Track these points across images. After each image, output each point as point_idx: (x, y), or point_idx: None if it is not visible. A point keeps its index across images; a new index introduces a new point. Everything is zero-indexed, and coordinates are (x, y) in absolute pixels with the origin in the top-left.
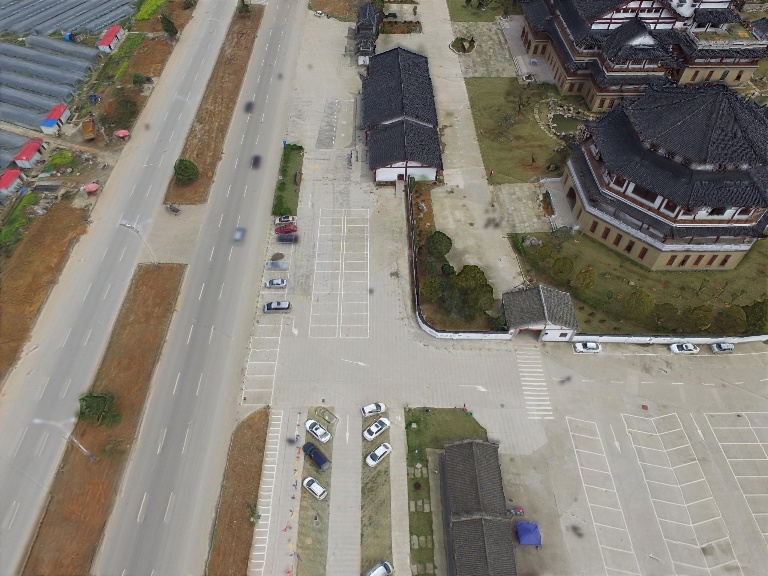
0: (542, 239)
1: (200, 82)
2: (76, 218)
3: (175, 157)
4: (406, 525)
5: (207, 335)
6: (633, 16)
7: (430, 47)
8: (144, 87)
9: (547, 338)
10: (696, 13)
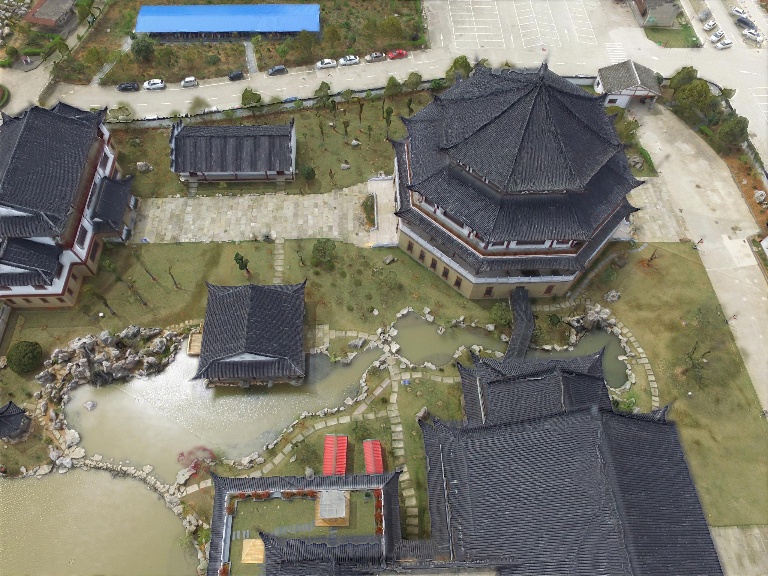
0: None
1: None
2: None
3: None
4: (683, 2)
5: None
6: None
7: None
8: None
9: None
10: None
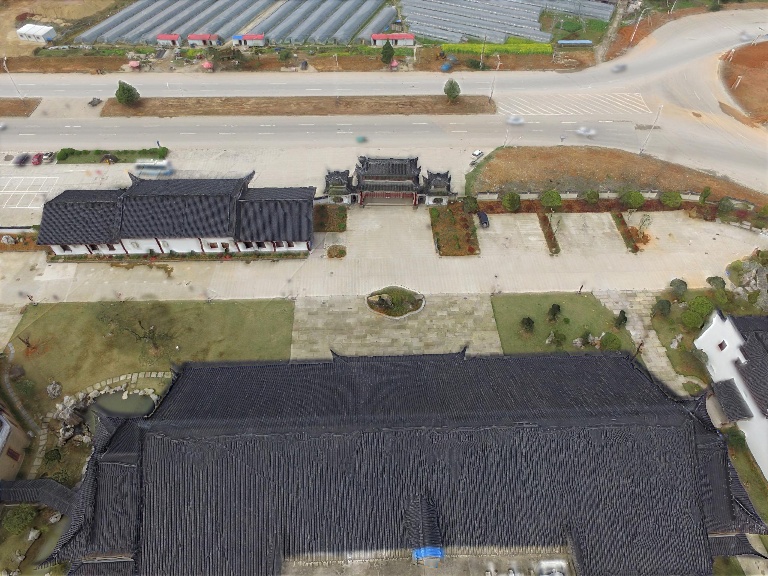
0: None
1: (303, 92)
2: (110, 68)
3: (175, 96)
4: None
5: None
6: None
7: (393, 263)
8: (296, 67)
9: None
10: None
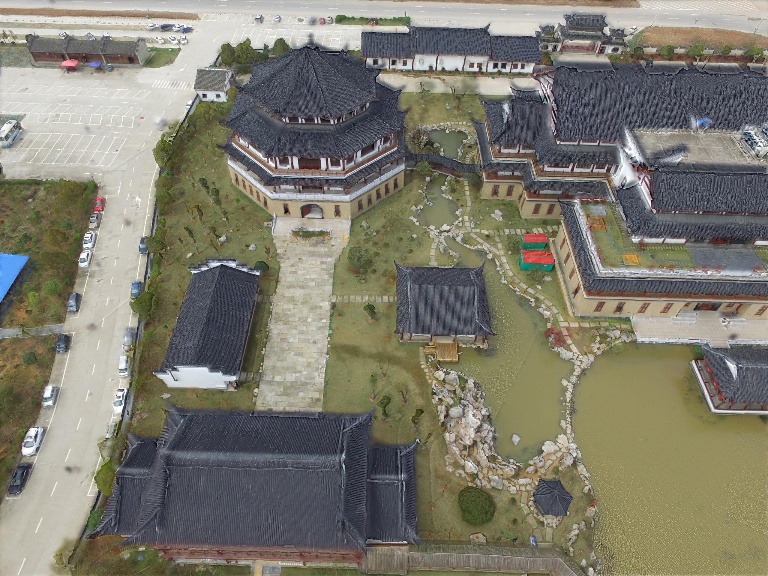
0: None
1: None
2: None
3: None
4: None
5: (248, 5)
6: None
7: None
8: None
9: None
10: None
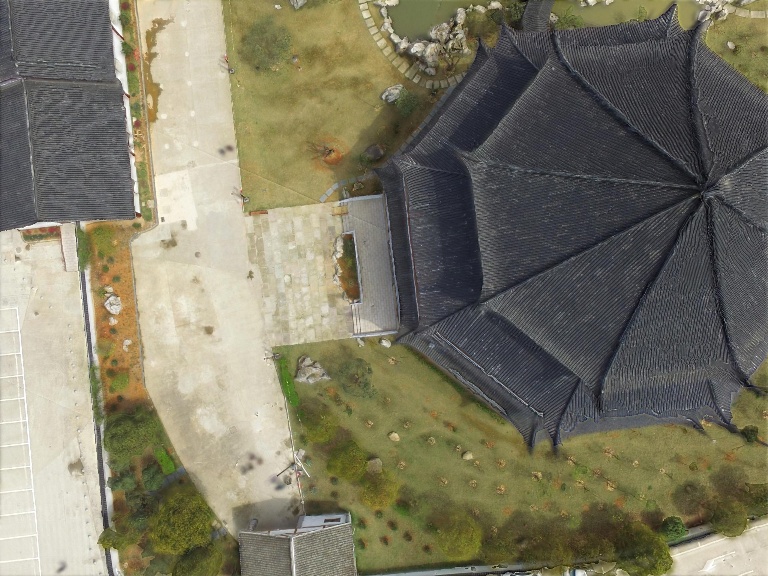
0: (332, 359)
1: None
2: None
3: None
4: None
5: None
6: None
7: None
8: None
9: None
10: None
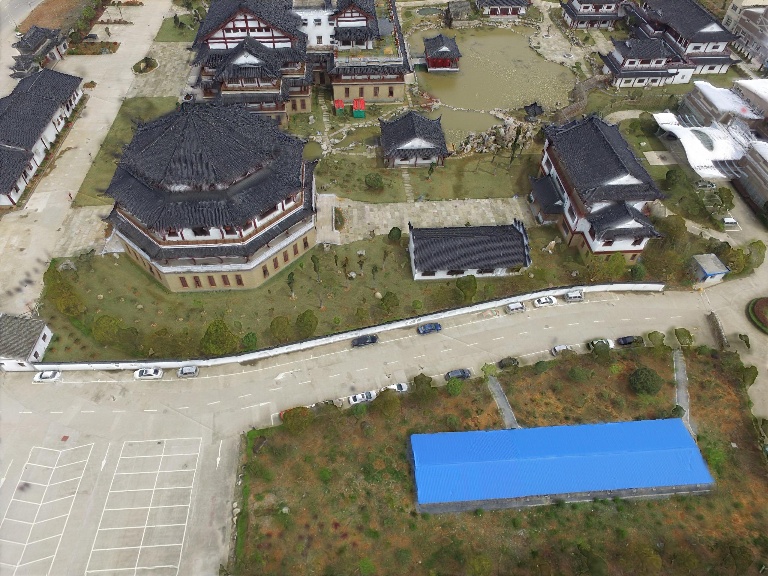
0: None
1: None
2: None
3: None
4: None
5: None
6: (245, 35)
7: (112, 68)
8: None
9: (12, 368)
10: (335, 31)
